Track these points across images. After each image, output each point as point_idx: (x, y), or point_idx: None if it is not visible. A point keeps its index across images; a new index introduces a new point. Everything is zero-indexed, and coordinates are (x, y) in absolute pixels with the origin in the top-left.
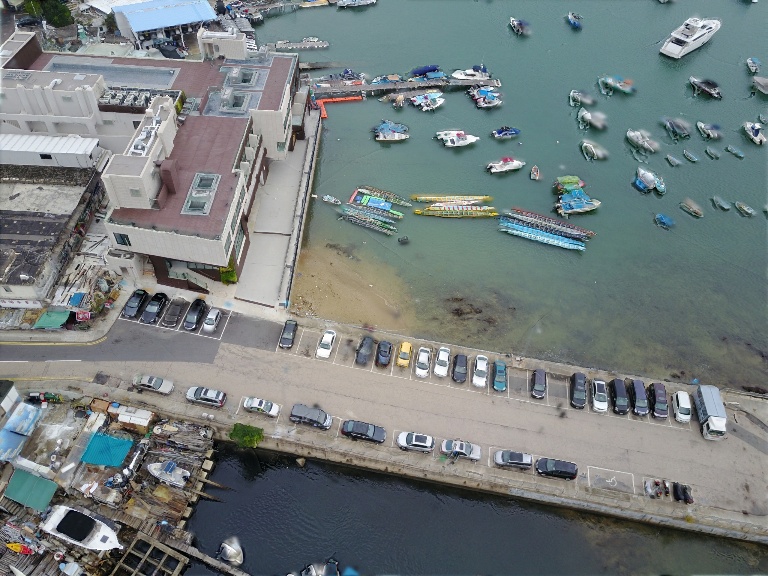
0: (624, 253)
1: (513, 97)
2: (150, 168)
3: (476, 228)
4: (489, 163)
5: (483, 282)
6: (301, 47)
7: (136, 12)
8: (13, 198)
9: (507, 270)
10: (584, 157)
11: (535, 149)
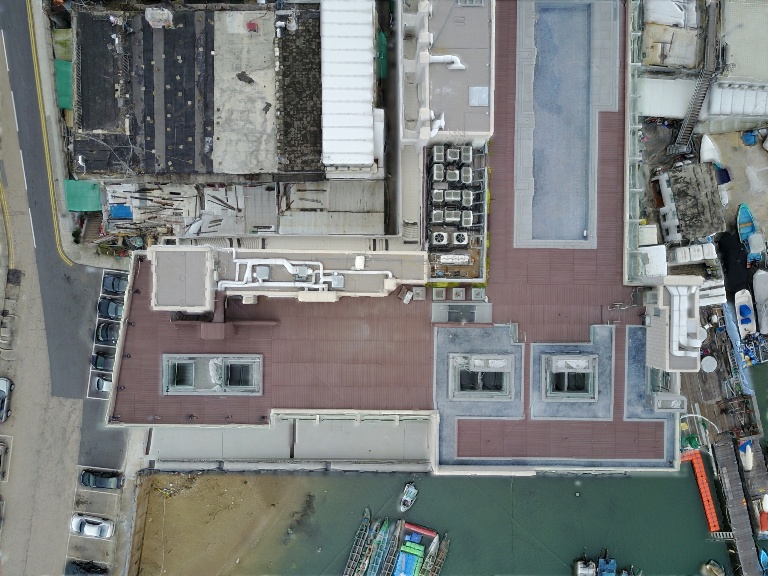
0: None
1: None
2: None
3: None
4: None
5: None
6: None
7: None
8: (241, 78)
9: None
10: None
11: None
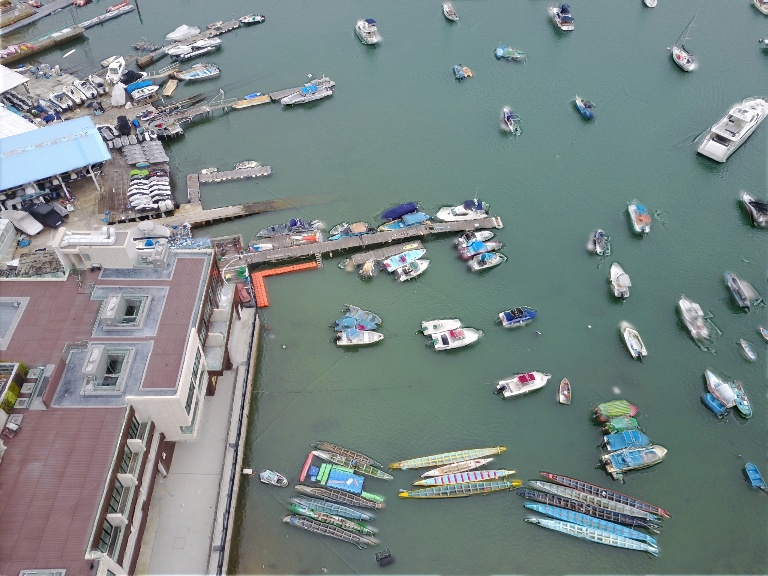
0: (713, 547)
1: (521, 247)
2: None
3: (491, 517)
4: (500, 380)
5: None
6: (233, 178)
7: None
8: None
9: None
10: (629, 353)
11: (559, 340)
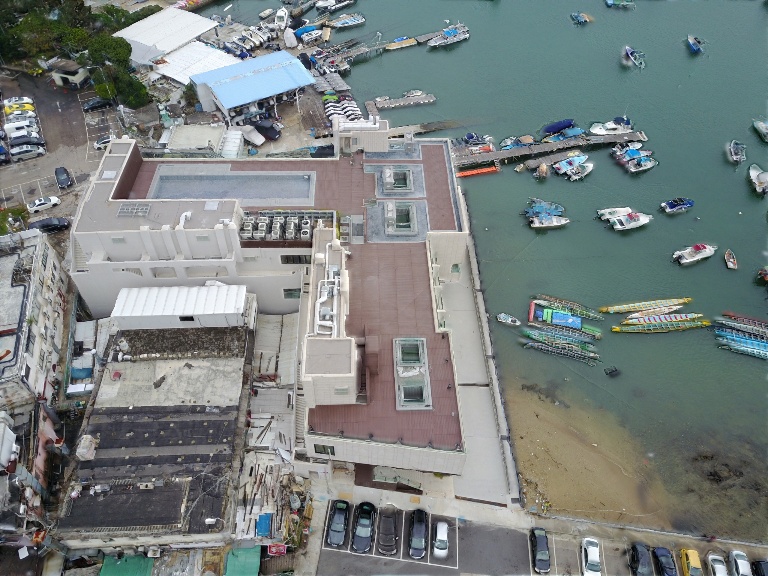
0: None
1: (667, 154)
2: (355, 354)
3: (690, 346)
4: (675, 251)
5: (727, 427)
6: (405, 104)
7: (222, 83)
8: (159, 385)
9: (748, 406)
10: None
11: (715, 224)
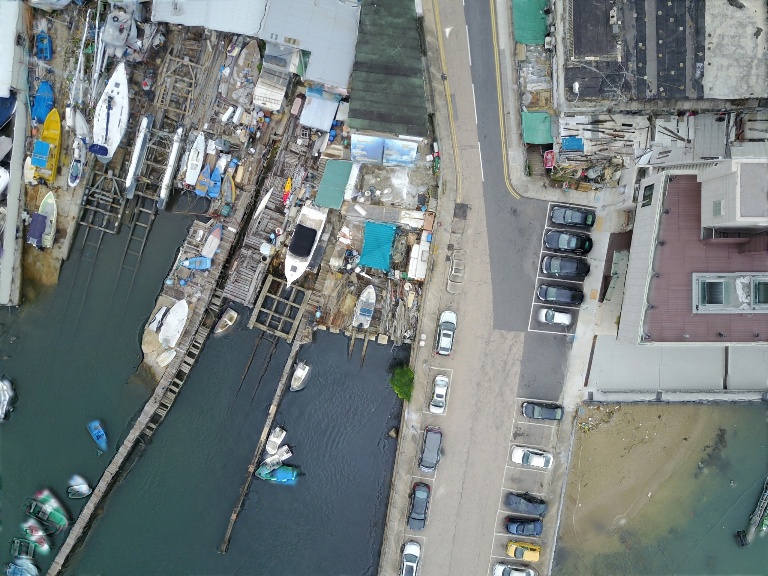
0: None
1: None
2: (767, 222)
3: None
4: None
5: None
6: None
7: None
8: (733, 3)
9: None
10: None
11: None
